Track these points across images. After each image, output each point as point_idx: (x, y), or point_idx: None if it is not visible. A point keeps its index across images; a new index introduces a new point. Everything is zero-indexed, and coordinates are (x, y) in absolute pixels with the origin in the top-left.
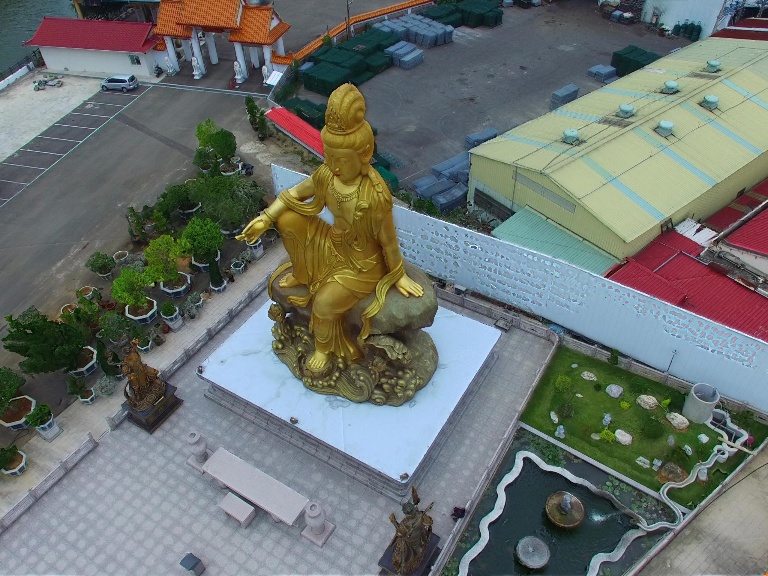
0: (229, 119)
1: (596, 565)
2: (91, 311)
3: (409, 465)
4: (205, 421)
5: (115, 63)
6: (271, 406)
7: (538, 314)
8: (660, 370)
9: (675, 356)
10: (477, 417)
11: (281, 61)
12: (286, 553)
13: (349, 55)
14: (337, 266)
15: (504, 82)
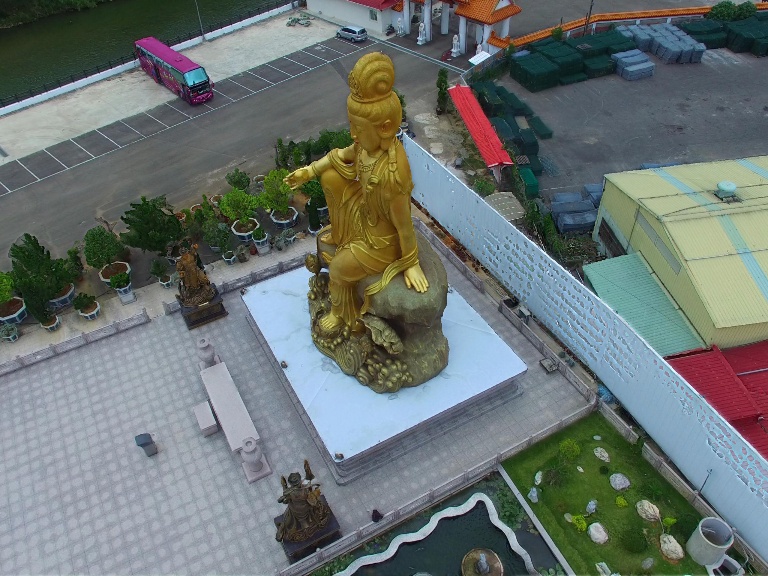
0: (423, 87)
1: None
2: (208, 215)
3: (351, 449)
4: (233, 337)
5: (358, 15)
6: (276, 345)
7: (592, 369)
8: (694, 486)
9: (710, 476)
10: (461, 440)
11: (496, 43)
12: (221, 473)
13: (568, 51)
14: (358, 235)
15: (732, 119)
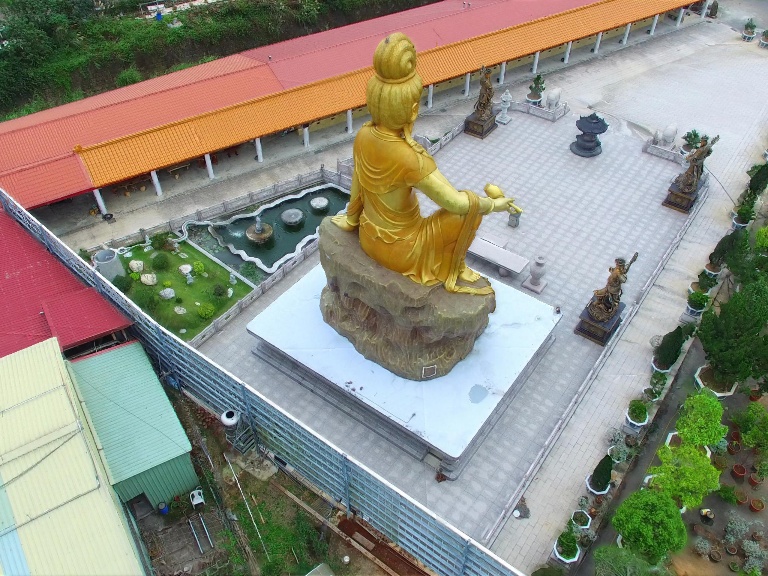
0: None
1: (256, 213)
2: None
3: None
4: None
5: None
6: None
7: None
8: None
9: None
10: None
11: None
12: None
13: None
14: None
15: None
